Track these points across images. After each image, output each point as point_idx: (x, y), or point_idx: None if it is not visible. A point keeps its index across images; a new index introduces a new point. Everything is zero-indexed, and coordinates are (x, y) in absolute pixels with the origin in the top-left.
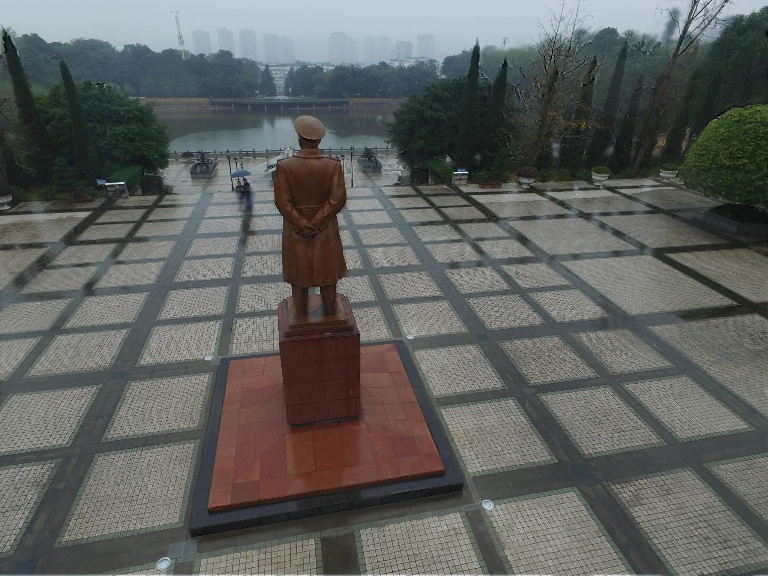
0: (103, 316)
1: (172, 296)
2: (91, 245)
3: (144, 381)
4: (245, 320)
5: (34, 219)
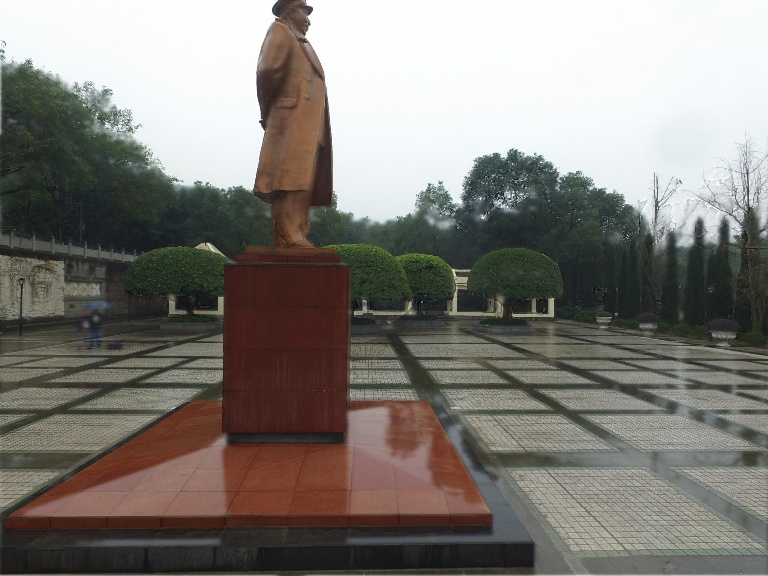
0: (531, 376)
1: (598, 390)
2: (688, 364)
3: (413, 392)
4: (561, 419)
5: (716, 351)
